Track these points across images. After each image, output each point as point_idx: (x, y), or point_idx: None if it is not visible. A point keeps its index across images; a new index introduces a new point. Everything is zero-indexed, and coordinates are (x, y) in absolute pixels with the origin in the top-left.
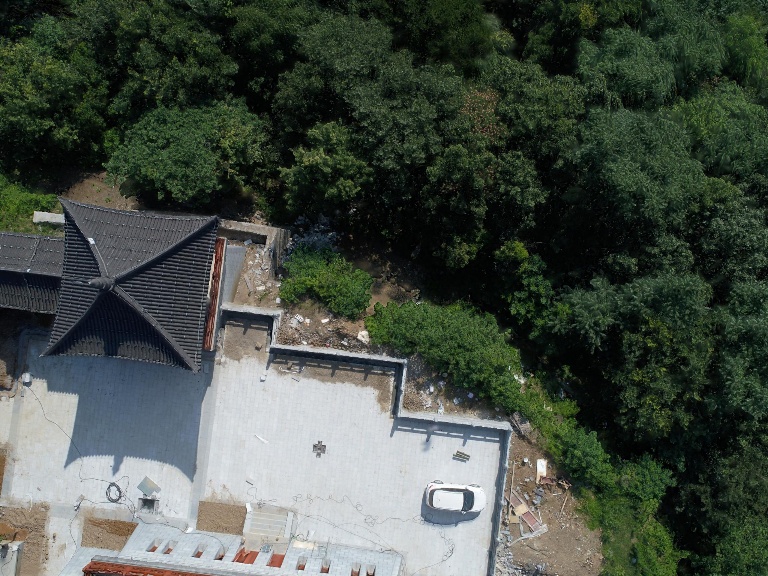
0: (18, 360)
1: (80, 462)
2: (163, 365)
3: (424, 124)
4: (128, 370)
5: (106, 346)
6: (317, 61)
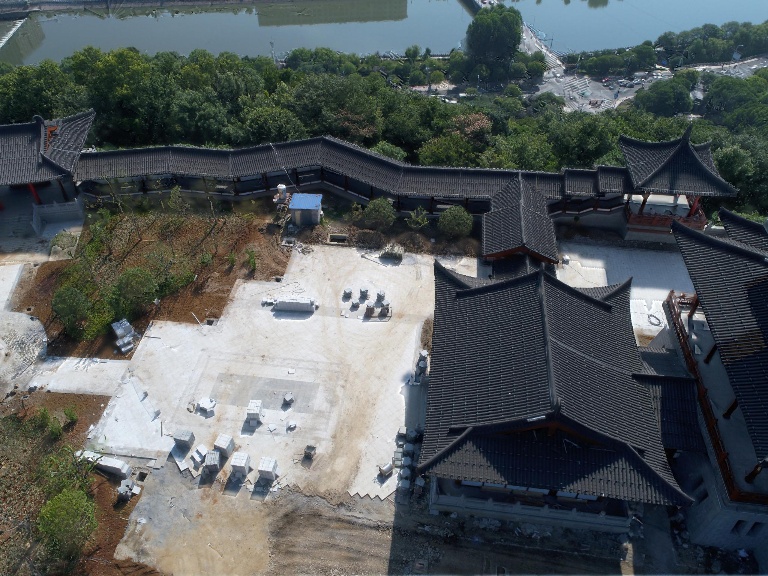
0: None
1: None
2: (658, 256)
3: None
4: (635, 258)
5: (671, 187)
6: None
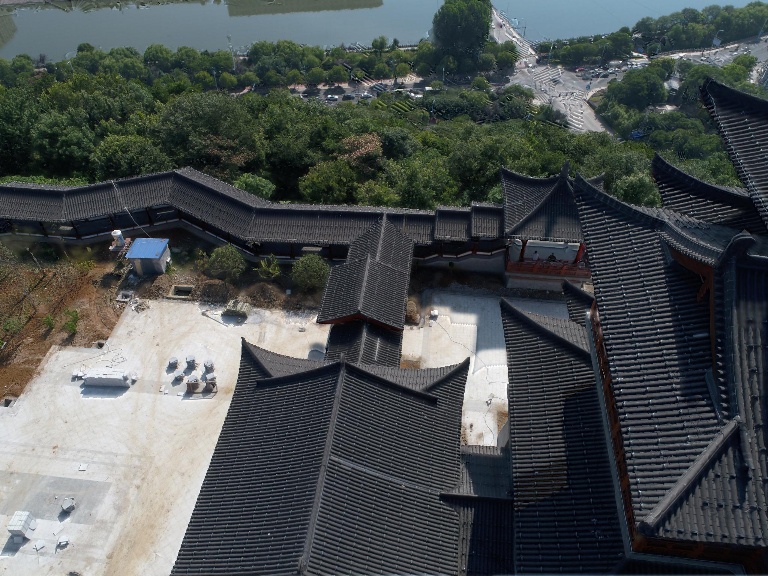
0: (423, 307)
1: (486, 370)
2: (541, 307)
3: (693, 173)
4: None
5: (547, 233)
6: (603, 164)
